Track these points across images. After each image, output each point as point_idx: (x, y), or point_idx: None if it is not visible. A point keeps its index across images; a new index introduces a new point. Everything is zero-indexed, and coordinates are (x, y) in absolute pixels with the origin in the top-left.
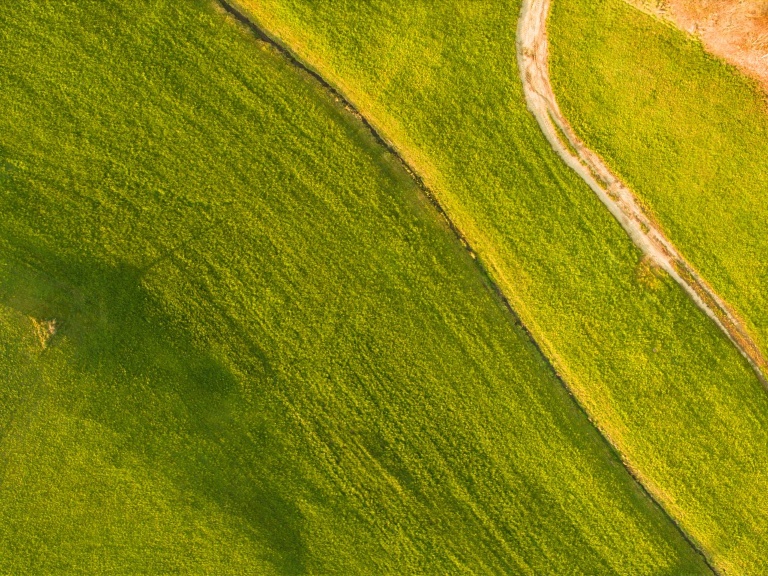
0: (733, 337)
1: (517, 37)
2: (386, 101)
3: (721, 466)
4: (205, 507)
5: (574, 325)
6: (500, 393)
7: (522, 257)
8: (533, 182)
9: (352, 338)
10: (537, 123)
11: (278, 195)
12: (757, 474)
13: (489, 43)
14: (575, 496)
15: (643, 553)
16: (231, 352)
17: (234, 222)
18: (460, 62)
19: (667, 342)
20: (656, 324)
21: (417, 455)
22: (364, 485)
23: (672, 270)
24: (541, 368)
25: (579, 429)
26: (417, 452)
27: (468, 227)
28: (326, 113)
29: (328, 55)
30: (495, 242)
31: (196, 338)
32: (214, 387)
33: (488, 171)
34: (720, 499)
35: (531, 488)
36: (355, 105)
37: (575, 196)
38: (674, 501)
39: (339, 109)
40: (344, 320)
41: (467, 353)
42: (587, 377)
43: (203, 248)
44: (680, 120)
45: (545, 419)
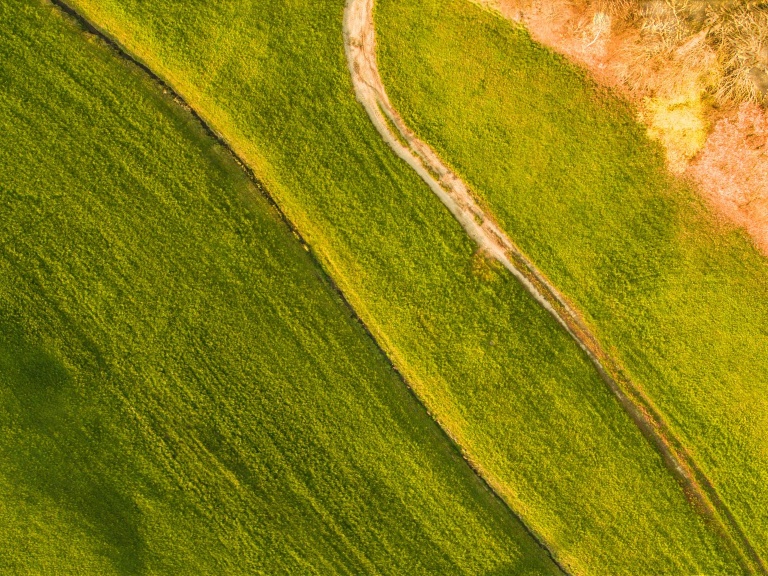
0: (571, 329)
1: (344, 27)
2: (214, 93)
3: (562, 460)
4: (40, 502)
5: (410, 318)
6: (336, 387)
7: (355, 249)
8: (364, 174)
9: (186, 332)
10: (367, 114)
11: (108, 188)
12: (599, 468)
13: (315, 33)
14: (415, 490)
15: (486, 548)
16: (64, 346)
17: (65, 215)
18: (287, 53)
19: (504, 335)
20: (492, 317)
21: (254, 449)
22: (201, 480)
23: (508, 262)
24: (378, 361)
25: (418, 423)
26: (254, 446)
27: (300, 219)
28: (154, 105)
29: (155, 47)
30: (328, 234)
31: (28, 332)
32: (47, 381)
33: (319, 163)
34: (562, 493)
35: (371, 482)
36: (184, 97)
37: (407, 187)
38: (516, 495)
39: (168, 101)
40: (177, 314)
41: (302, 346)
42: (424, 370)
43: (34, 242)
44: (510, 110)
45: (383, 413)
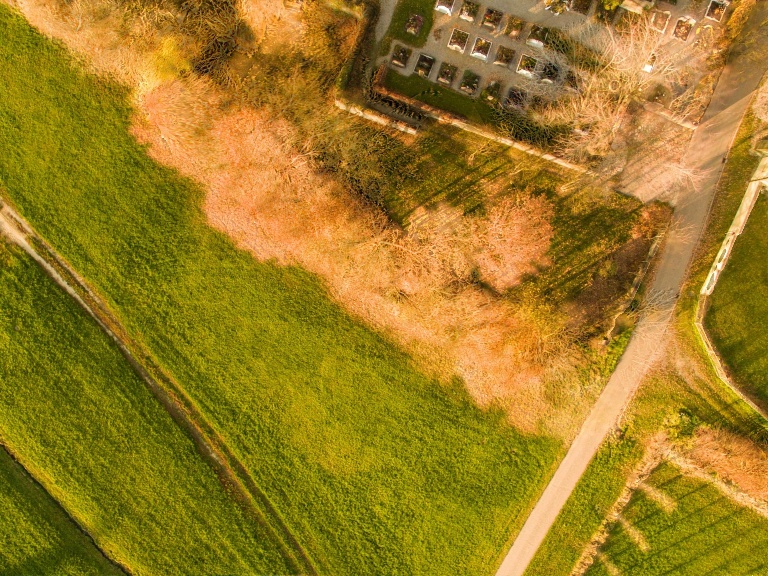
0: (96, 315)
1: None
2: None
3: (95, 446)
4: None
5: None
6: None
7: None
8: None
9: None
10: None
11: None
12: (132, 454)
13: None
14: None
15: (25, 533)
16: None
17: None
18: None
19: (28, 320)
20: (15, 302)
21: None
22: None
23: (29, 247)
24: None
25: None
26: None
27: None
28: None
29: None
30: None
31: None
32: None
33: None
34: (98, 479)
35: None
36: None
37: None
38: (53, 481)
39: None
40: None
41: None
42: None
43: None
44: (17, 95)
45: None
